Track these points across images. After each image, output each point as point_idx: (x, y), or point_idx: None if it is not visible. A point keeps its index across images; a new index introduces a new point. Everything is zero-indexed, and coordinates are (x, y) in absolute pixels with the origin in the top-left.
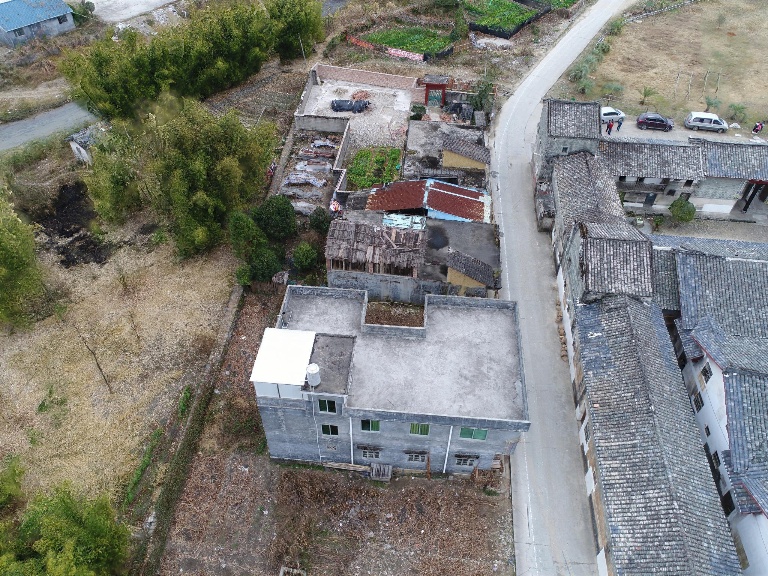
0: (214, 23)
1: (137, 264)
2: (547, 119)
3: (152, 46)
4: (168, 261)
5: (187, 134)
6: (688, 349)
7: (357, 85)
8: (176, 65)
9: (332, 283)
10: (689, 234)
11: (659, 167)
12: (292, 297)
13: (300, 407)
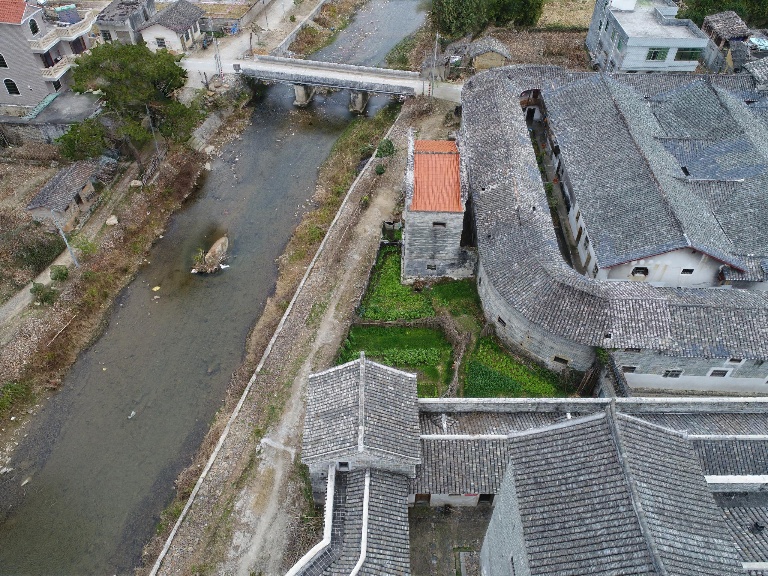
0: None
1: None
2: None
3: None
4: None
5: None
6: None
7: None
8: None
9: None
10: None
11: None
12: None
13: None
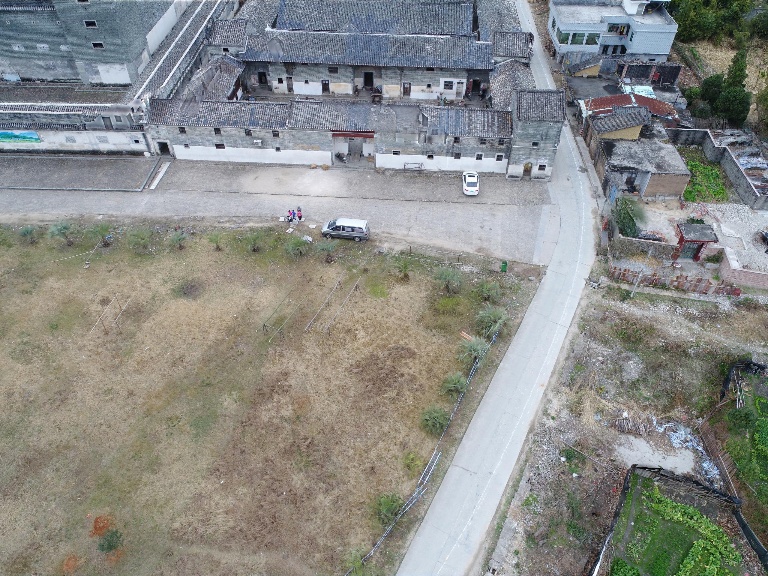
0: None
1: None
2: None
3: None
4: None
5: None
6: None
7: None
8: None
9: None
10: None
11: None
12: None
13: None
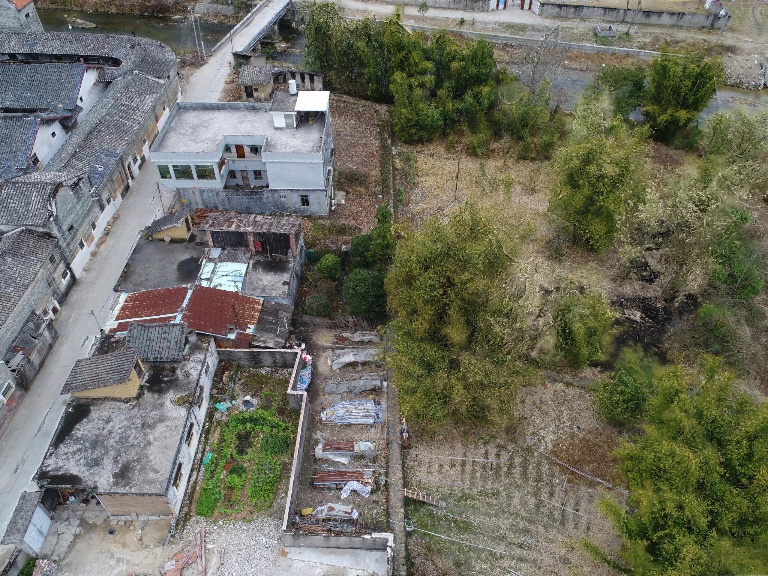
0: None
1: None
2: None
3: None
4: None
5: (455, 216)
6: None
7: None
8: None
9: None
10: None
11: None
12: None
13: None
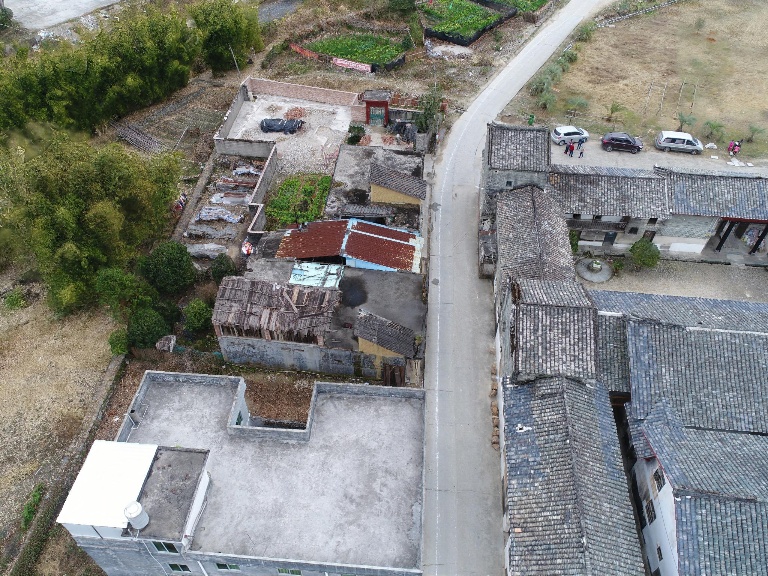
0: (124, 34)
1: (9, 322)
2: (488, 148)
3: (41, 63)
4: (44, 319)
5: (50, 175)
6: (638, 445)
7: (293, 101)
8: (75, 83)
9: (226, 350)
10: (653, 279)
11: (618, 203)
12: (152, 384)
13: (132, 547)
